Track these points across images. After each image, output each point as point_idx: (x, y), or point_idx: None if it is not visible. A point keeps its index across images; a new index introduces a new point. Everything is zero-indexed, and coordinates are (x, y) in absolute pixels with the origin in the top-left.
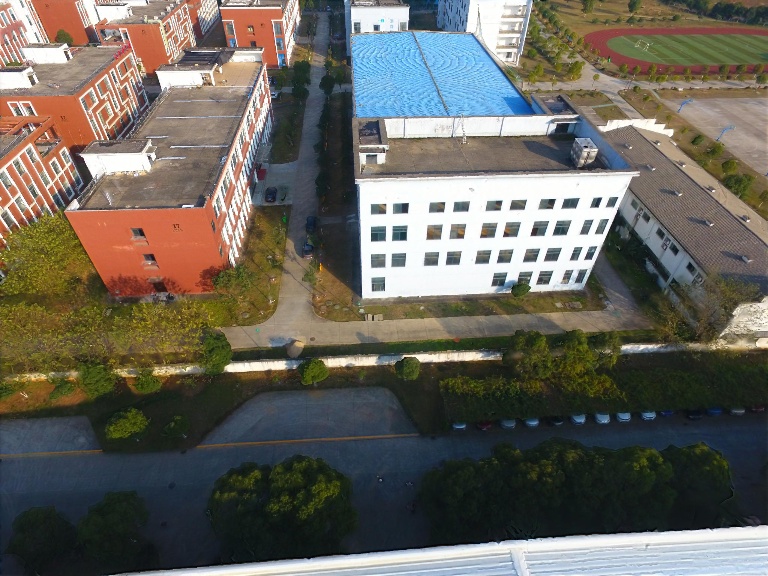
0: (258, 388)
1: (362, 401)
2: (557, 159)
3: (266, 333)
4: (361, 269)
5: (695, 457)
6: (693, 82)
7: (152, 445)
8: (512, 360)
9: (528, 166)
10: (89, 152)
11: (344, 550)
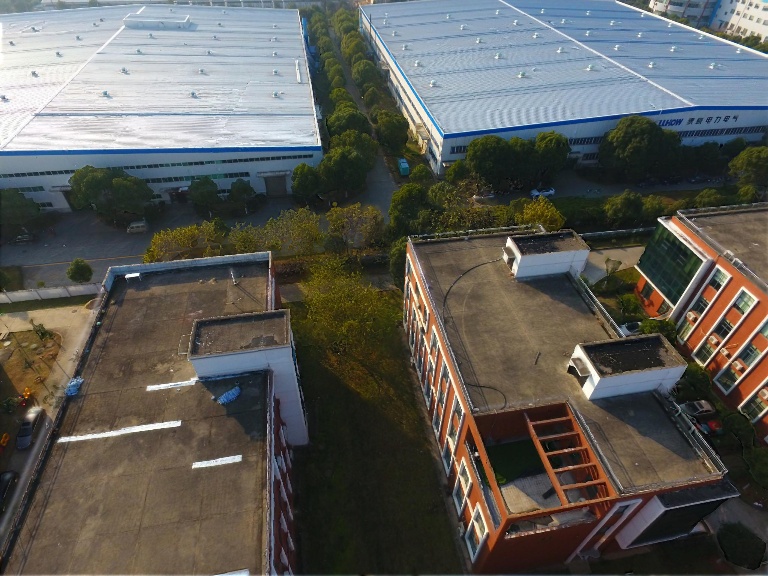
0: None
1: (54, 282)
2: None
3: None
4: None
5: None
6: None
7: (212, 248)
8: None
9: None
10: (281, 320)
11: (99, 222)
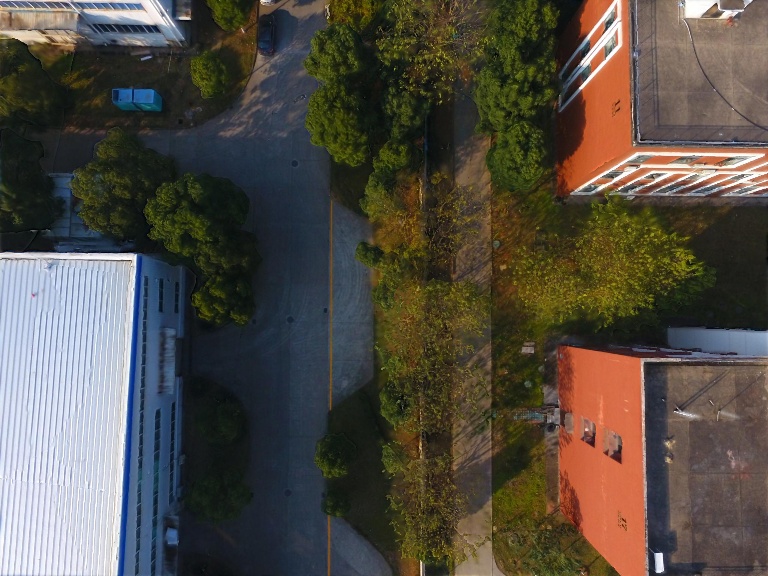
0: (397, 568)
1: None
2: None
3: (478, 575)
4: None
5: None
6: None
7: None
8: None
9: None
10: None
11: None
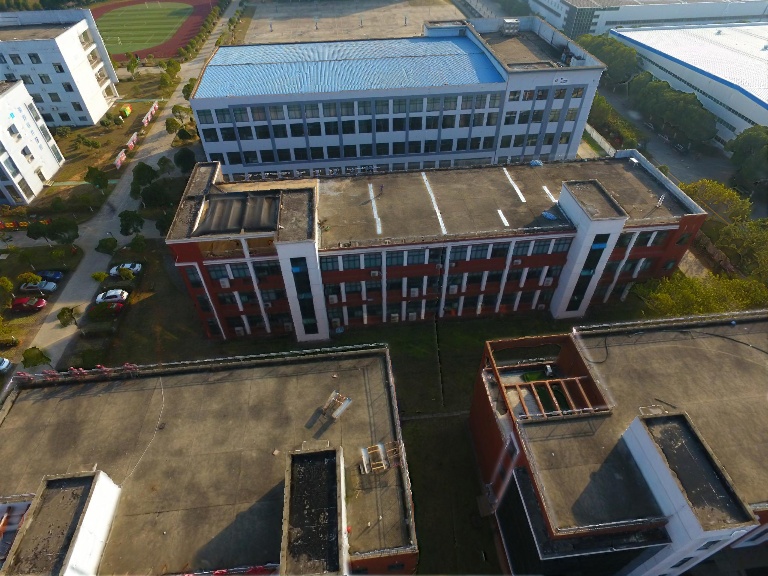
0: None
1: None
2: (506, 39)
3: None
4: (574, 148)
5: (645, 78)
6: (209, 42)
7: None
8: (605, 117)
9: (520, 45)
10: (617, 215)
11: None
